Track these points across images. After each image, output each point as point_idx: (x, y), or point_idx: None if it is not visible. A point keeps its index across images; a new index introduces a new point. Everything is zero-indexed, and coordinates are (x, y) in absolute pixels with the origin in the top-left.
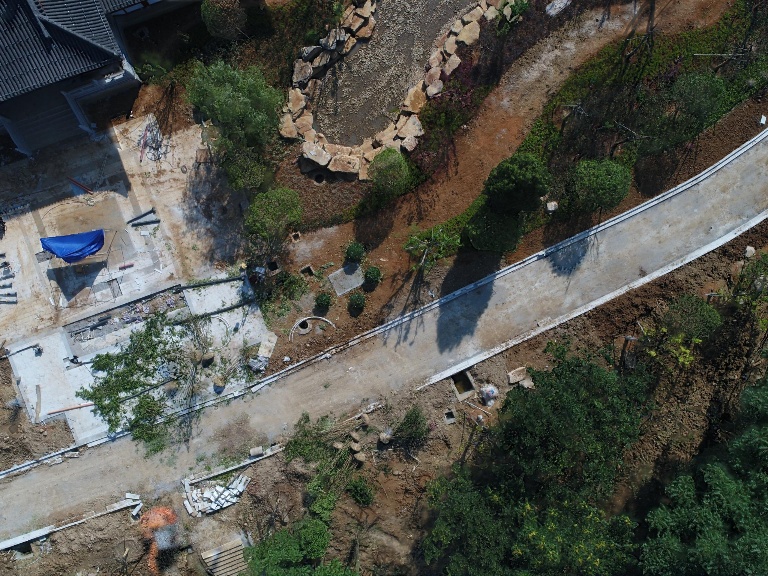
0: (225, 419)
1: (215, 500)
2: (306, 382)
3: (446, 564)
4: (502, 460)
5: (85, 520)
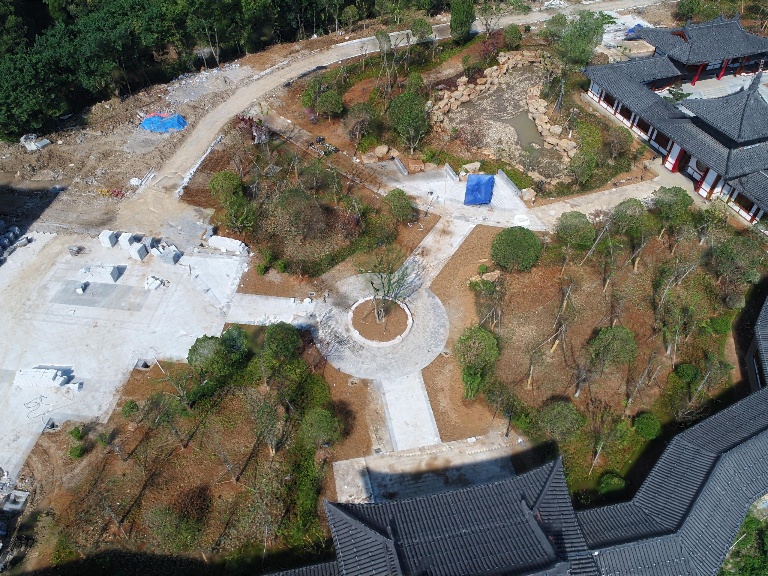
0: None
1: (554, 0)
2: (528, 20)
3: None
4: None
5: None
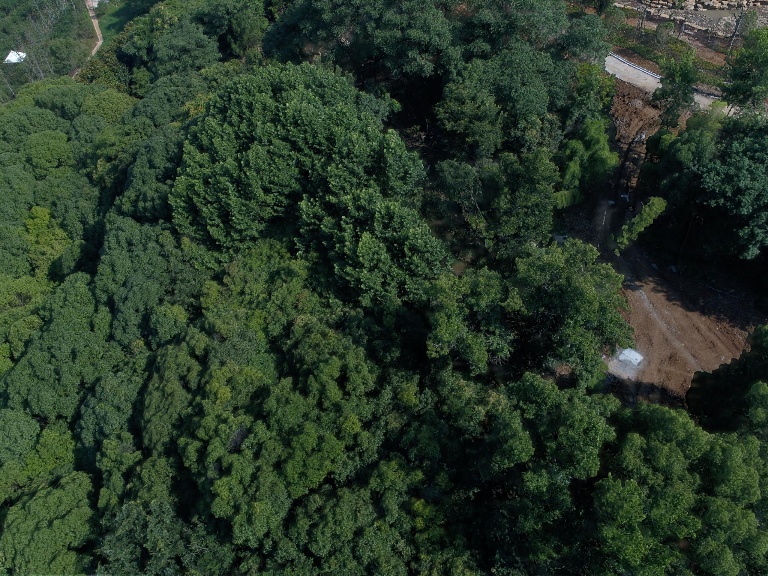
0: None
1: None
2: None
3: None
4: None
5: None
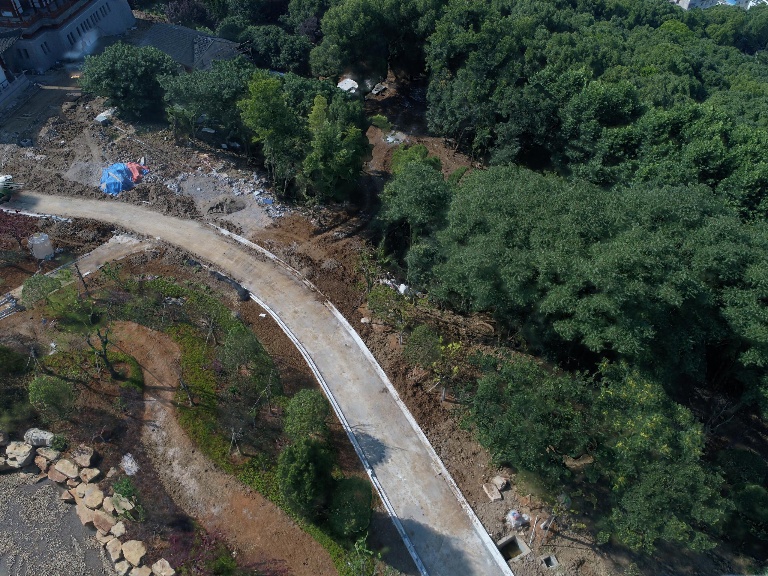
0: None
1: None
2: None
3: (712, 570)
4: (581, 505)
5: None
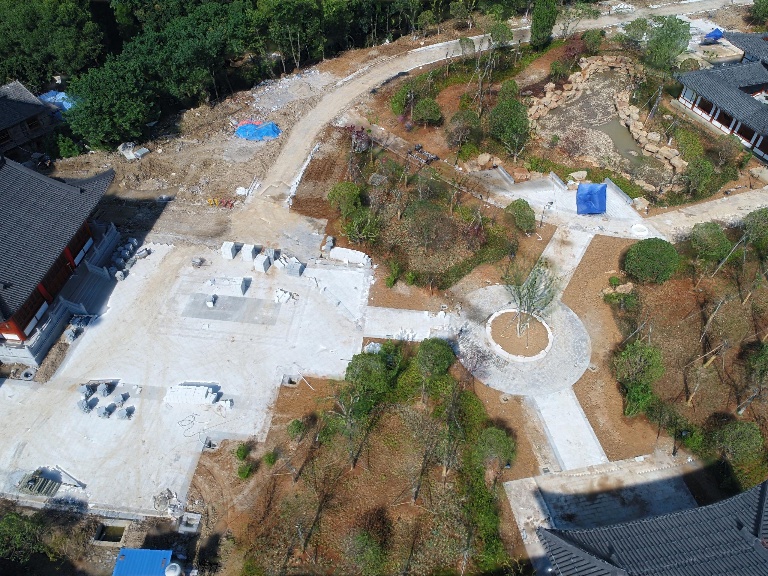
0: (628, 19)
1: (622, 4)
2: None
3: None
4: None
5: (669, 3)
